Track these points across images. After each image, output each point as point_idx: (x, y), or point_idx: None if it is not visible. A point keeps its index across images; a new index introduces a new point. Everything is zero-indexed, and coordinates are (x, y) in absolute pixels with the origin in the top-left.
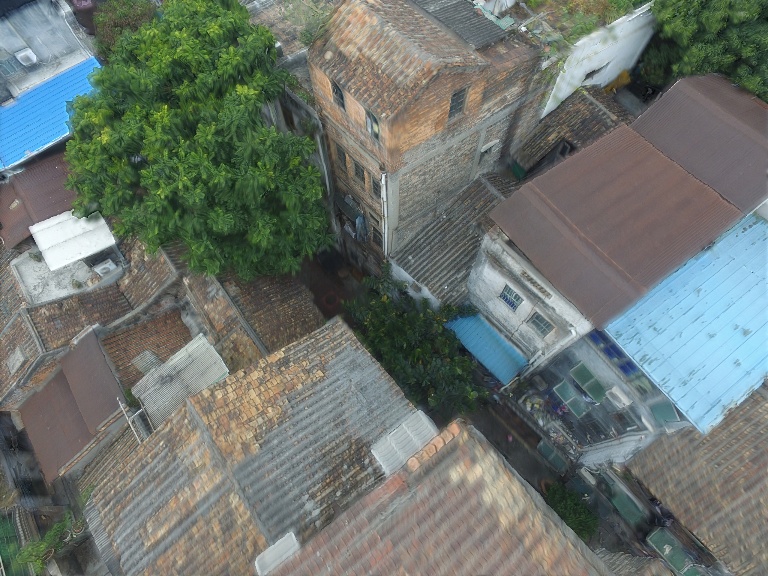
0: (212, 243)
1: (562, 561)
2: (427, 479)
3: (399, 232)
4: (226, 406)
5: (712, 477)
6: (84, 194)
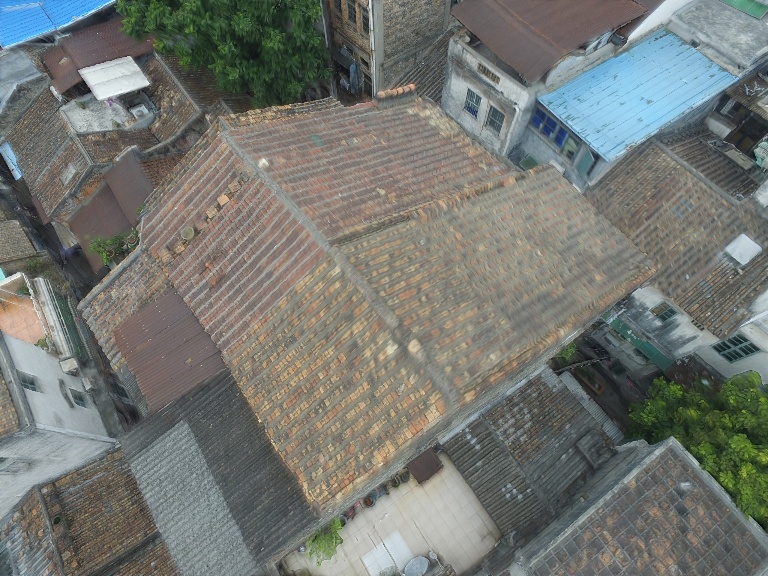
0: (233, 50)
1: (481, 156)
2: (391, 109)
3: (385, 72)
4: (248, 125)
5: (622, 215)
6: (131, 15)
